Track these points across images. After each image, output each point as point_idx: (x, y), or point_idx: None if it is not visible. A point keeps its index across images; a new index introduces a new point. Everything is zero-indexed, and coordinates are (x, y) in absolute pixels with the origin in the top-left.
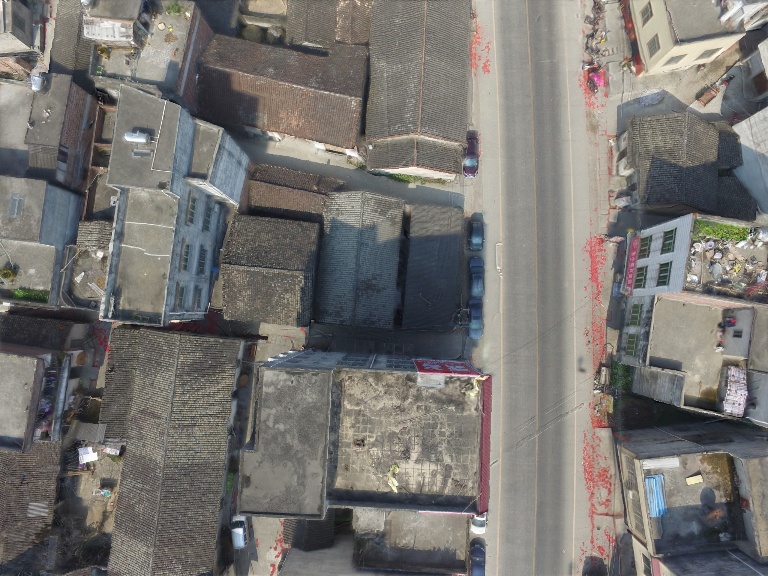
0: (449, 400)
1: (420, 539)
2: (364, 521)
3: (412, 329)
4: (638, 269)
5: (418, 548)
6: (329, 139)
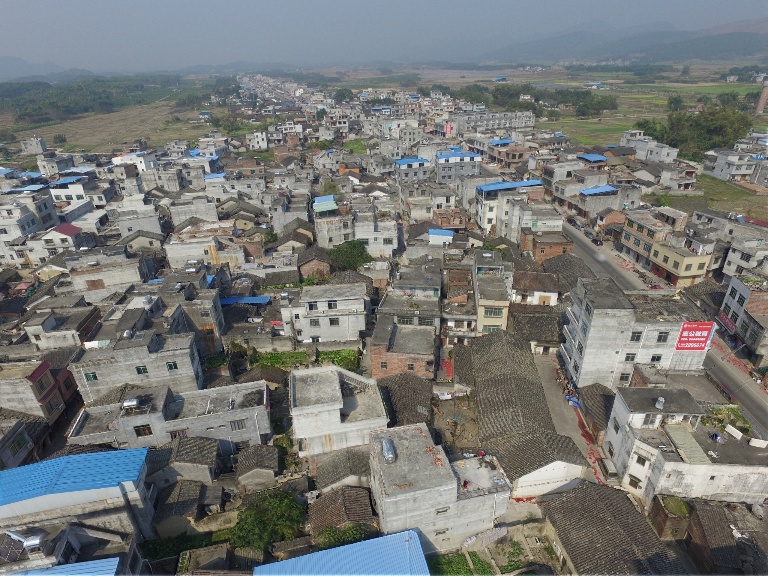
0: None
1: None
2: (654, 379)
3: None
4: (731, 318)
5: None
6: (546, 289)
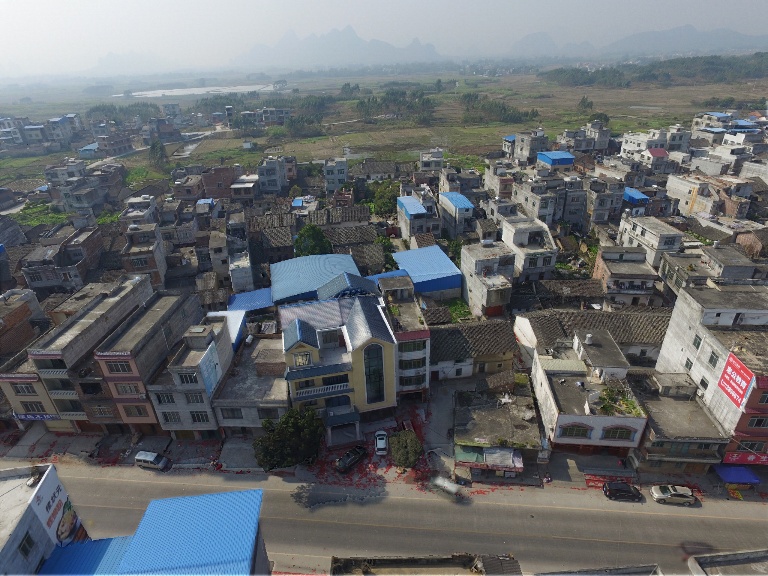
0: None
1: (658, 415)
2: (662, 377)
3: None
4: None
5: (651, 414)
6: None
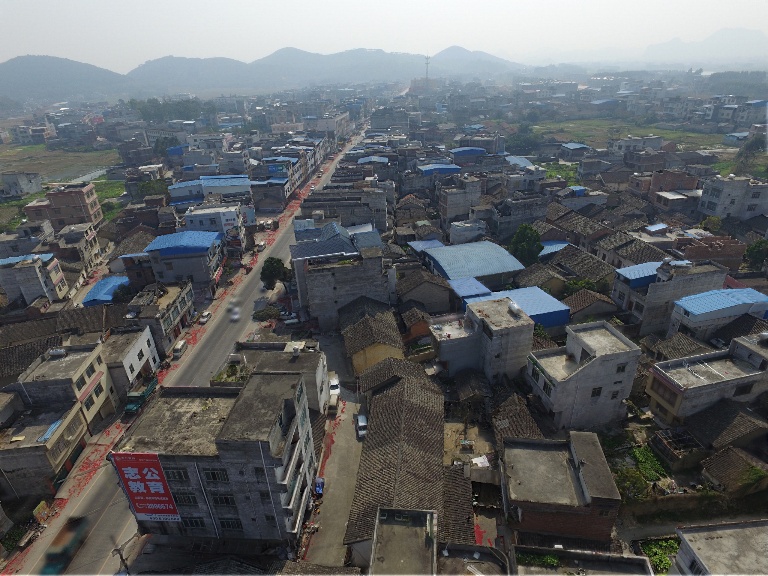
0: (147, 444)
1: None
2: None
3: (178, 569)
4: None
5: None
6: None
